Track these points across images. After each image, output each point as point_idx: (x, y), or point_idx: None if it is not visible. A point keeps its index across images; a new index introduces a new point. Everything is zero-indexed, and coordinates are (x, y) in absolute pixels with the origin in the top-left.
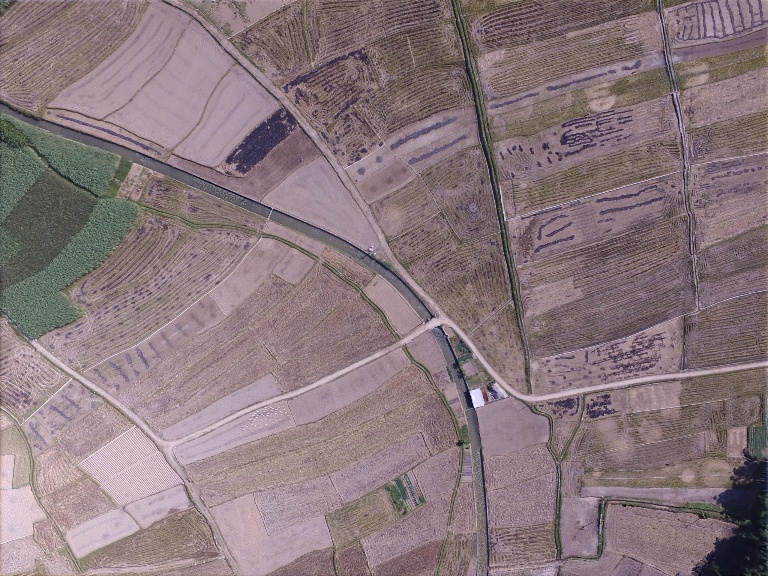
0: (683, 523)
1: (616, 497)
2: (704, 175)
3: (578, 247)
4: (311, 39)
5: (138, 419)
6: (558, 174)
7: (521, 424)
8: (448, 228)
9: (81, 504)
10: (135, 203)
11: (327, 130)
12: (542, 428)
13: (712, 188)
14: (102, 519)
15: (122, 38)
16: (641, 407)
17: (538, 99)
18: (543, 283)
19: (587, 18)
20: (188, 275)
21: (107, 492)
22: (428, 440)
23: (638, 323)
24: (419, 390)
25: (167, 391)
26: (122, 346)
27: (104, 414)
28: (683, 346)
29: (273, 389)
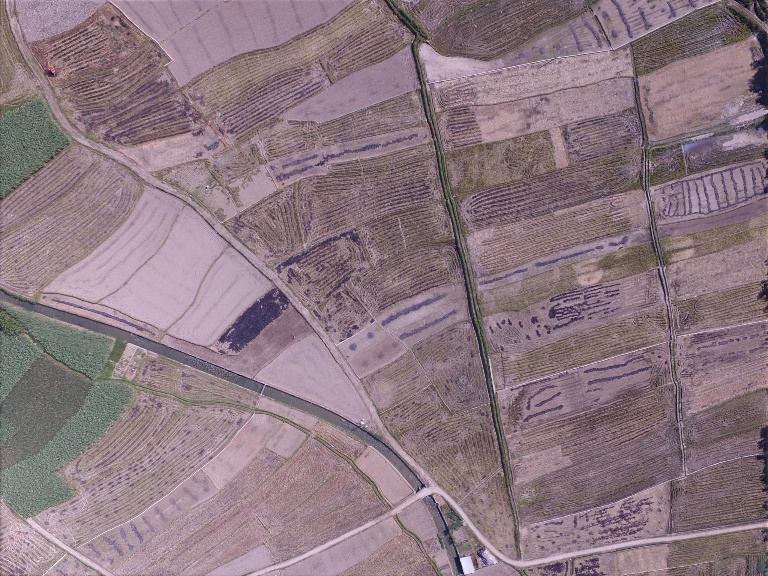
0: None
1: None
2: (690, 345)
3: (566, 416)
4: (303, 221)
5: None
6: (547, 346)
7: None
8: (438, 400)
9: None
10: (129, 384)
11: (319, 308)
12: None
13: (698, 358)
14: None
15: (117, 224)
16: (629, 570)
17: (527, 275)
18: (532, 452)
19: (575, 196)
20: (182, 451)
21: None
22: None
23: (626, 489)
24: (410, 558)
25: (161, 564)
26: (116, 521)
27: None
28: (670, 510)
29: (266, 559)
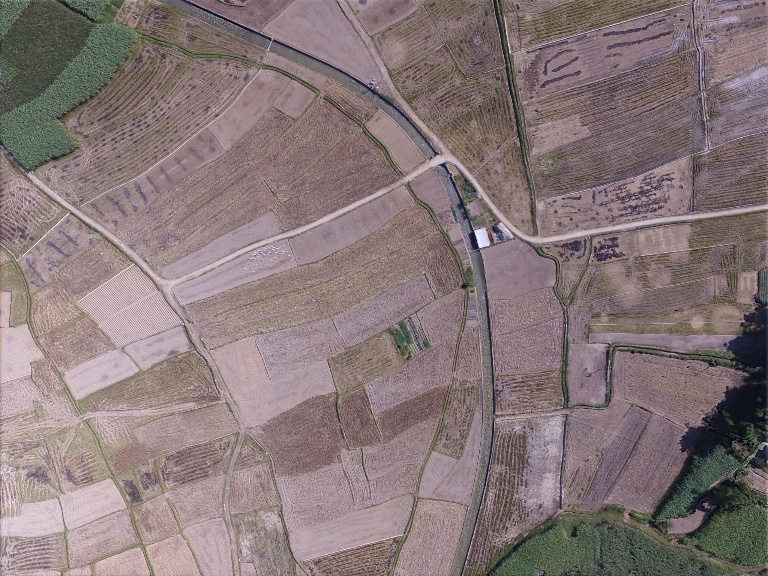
0: (693, 371)
1: (624, 343)
2: (714, 8)
3: (585, 83)
4: None
5: (137, 256)
6: (564, 6)
7: (527, 267)
8: (452, 62)
9: (79, 344)
10: (132, 29)
11: None
12: (548, 271)
13: (722, 22)
14: (101, 360)
15: None
16: (649, 250)
17: None
18: (549, 120)
19: None
20: (187, 107)
21: (106, 332)
22: (432, 282)
23: (646, 163)
24: (423, 230)
25: (166, 228)
26: (120, 180)
27: (102, 251)
28: (692, 187)
29: (274, 227)
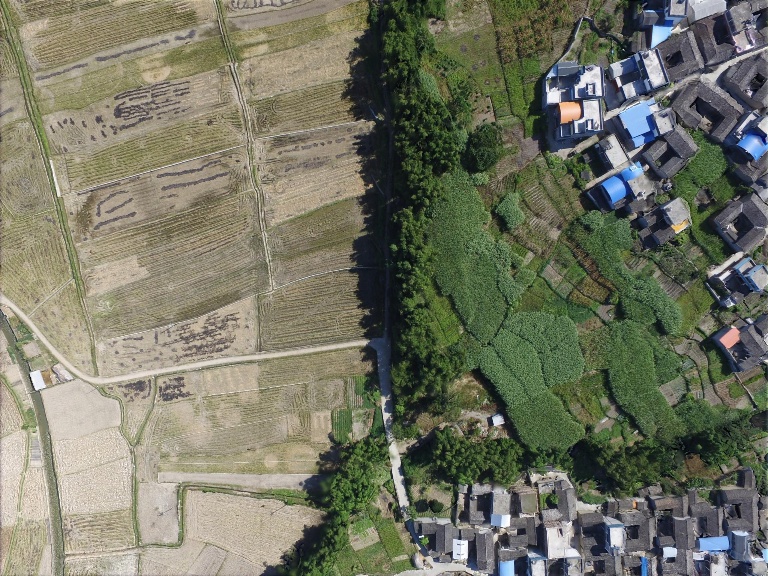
0: (268, 510)
1: (194, 483)
2: (270, 149)
3: (140, 224)
4: None
5: None
6: (114, 148)
7: (90, 407)
8: (0, 204)
9: None
10: None
11: None
12: (113, 411)
13: (280, 163)
14: None
15: None
16: (217, 390)
17: (87, 70)
18: (105, 261)
19: None
20: None
21: None
22: None
23: (209, 303)
24: None
25: None
26: None
27: None
28: (259, 327)
29: None
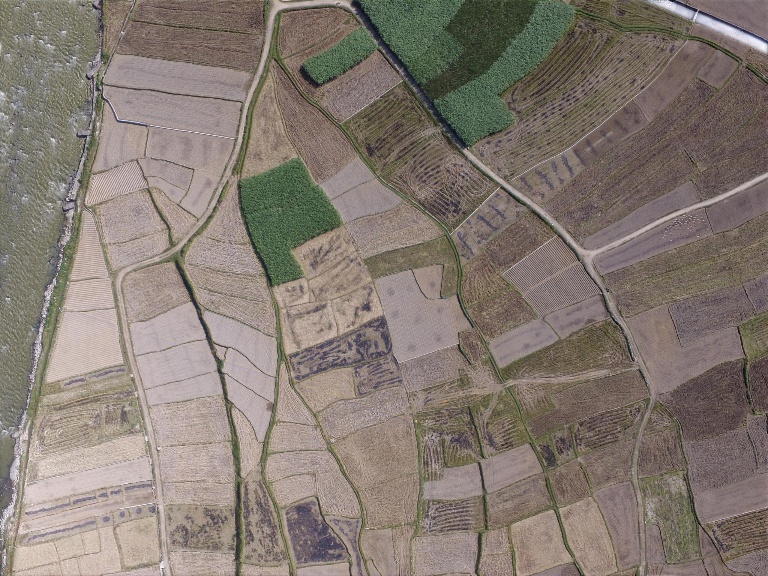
0: None
1: None
2: None
3: None
4: None
5: (561, 228)
6: None
7: None
8: None
9: (505, 314)
10: None
11: None
12: None
13: None
14: (523, 329)
15: None
16: None
17: None
18: None
19: None
20: (614, 80)
21: (528, 302)
22: None
23: None
24: None
25: (589, 199)
26: (548, 154)
27: (527, 224)
28: None
29: (692, 196)
